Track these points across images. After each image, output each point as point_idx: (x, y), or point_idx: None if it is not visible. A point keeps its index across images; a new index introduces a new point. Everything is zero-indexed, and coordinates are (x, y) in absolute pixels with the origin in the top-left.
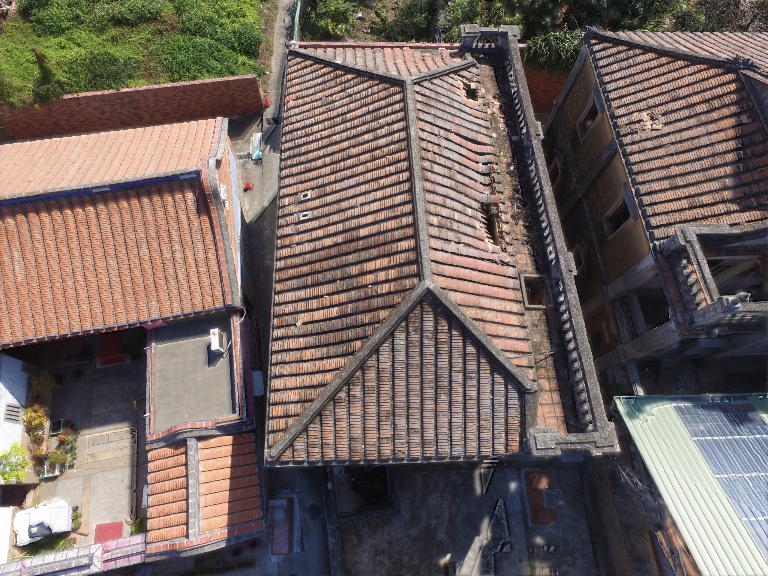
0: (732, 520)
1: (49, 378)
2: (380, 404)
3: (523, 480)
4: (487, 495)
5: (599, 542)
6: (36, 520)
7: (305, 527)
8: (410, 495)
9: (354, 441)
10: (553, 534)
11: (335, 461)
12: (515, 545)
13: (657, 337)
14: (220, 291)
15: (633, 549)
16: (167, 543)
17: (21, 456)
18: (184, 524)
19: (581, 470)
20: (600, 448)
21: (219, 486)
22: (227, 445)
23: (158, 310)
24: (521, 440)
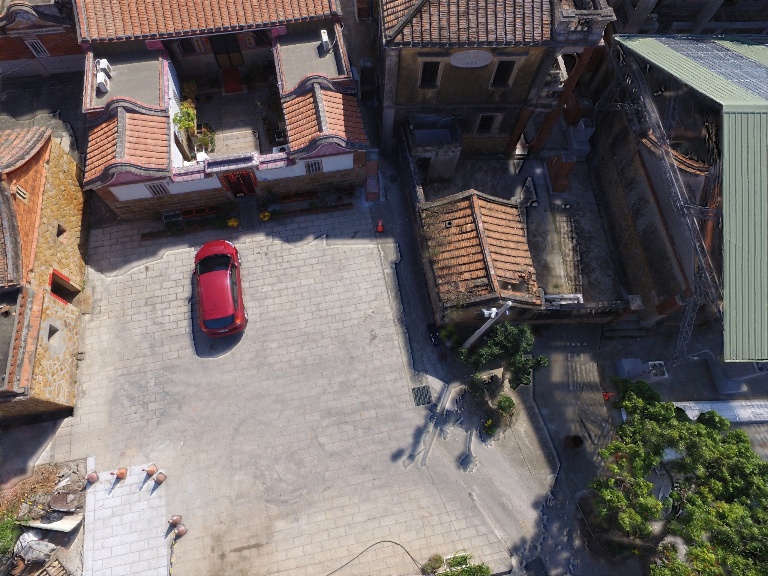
0: (688, 61)
1: (195, 85)
2: (459, 6)
3: (546, 168)
4: (519, 175)
5: (603, 205)
6: (202, 158)
7: (387, 187)
8: (462, 173)
9: (443, 29)
10: (569, 199)
11: (430, 45)
12: (541, 203)
13: (643, 2)
14: (327, 3)
15: (627, 180)
16: (306, 142)
17: (191, 112)
18: (317, 131)
19: (589, 164)
20: (604, 17)
21: (337, 116)
22: (339, 98)
23: (284, 15)
24: (552, 33)
